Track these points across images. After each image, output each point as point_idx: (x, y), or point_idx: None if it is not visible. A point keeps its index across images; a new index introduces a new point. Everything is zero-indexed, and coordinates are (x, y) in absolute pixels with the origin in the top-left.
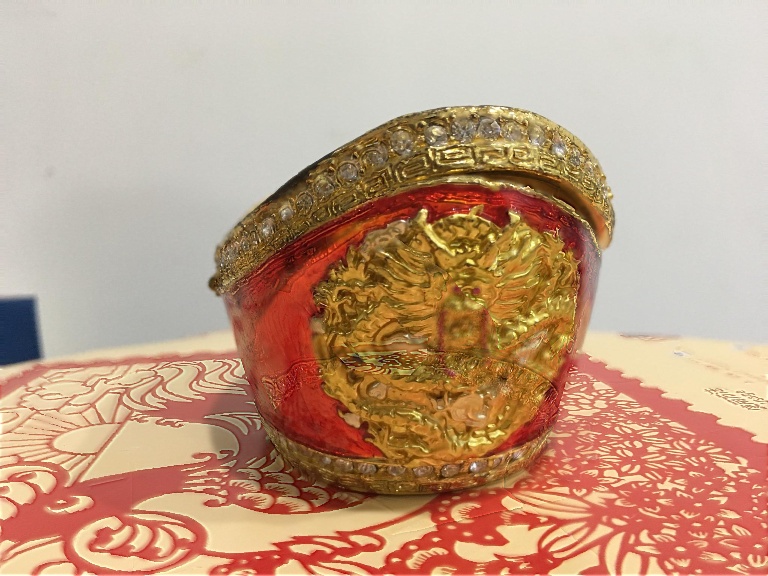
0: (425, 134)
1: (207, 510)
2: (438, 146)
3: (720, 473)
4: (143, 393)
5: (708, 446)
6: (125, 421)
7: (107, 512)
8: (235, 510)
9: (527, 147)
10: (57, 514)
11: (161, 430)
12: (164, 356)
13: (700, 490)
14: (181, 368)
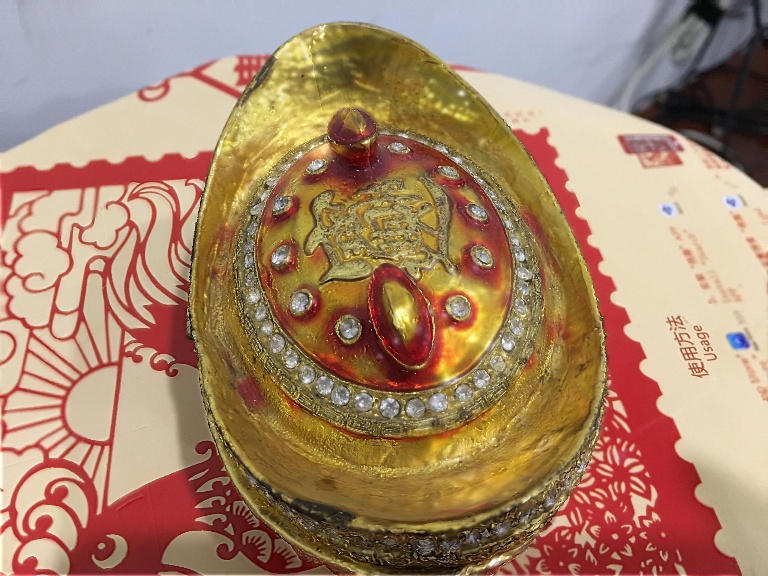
0: (412, 544)
1: (221, 568)
2: (424, 552)
3: (629, 517)
4: (125, 276)
5: (634, 460)
6: (121, 359)
7: (142, 565)
8: (243, 573)
9: (514, 535)
10: (103, 572)
11: (158, 384)
12: (129, 156)
13: (606, 549)
14: (153, 201)
